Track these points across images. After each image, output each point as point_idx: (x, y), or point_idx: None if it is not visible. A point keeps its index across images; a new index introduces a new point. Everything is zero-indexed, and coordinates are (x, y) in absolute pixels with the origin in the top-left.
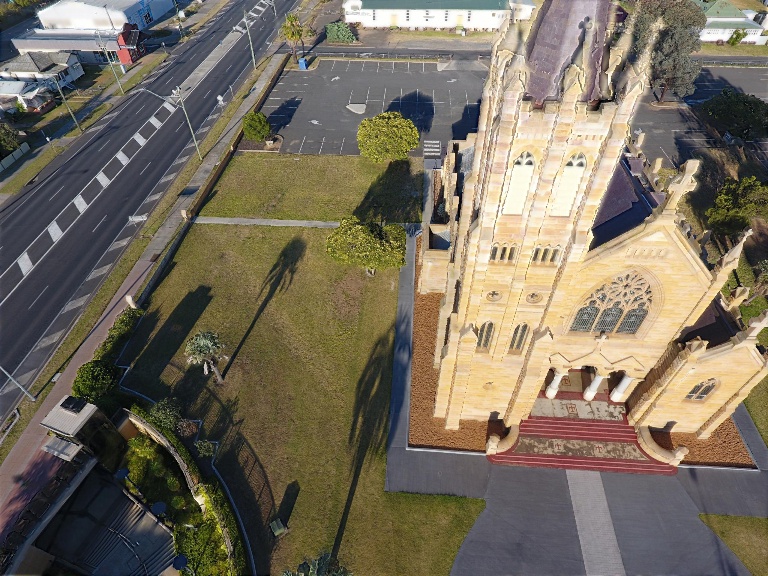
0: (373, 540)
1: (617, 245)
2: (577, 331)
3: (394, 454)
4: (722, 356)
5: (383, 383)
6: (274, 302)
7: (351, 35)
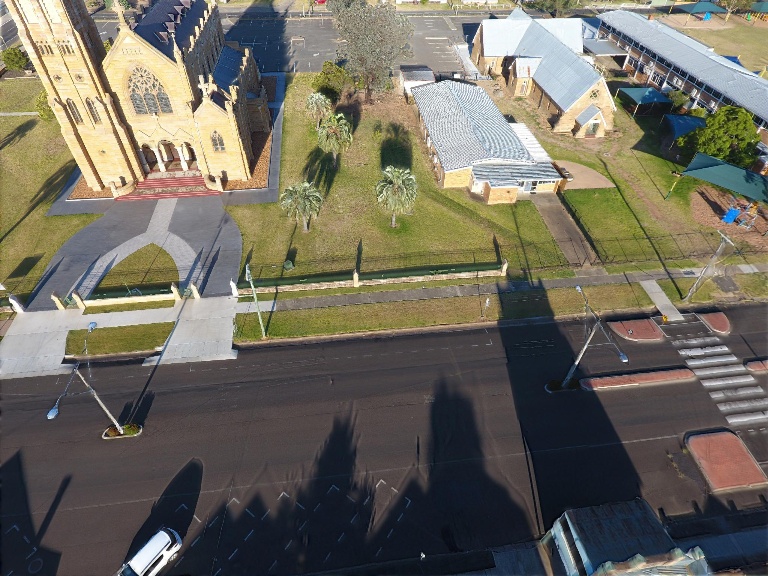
0: (28, 232)
1: (114, 47)
2: (142, 114)
3: (57, 203)
4: (203, 111)
5: (64, 178)
6: (2, 151)
7: (126, 3)
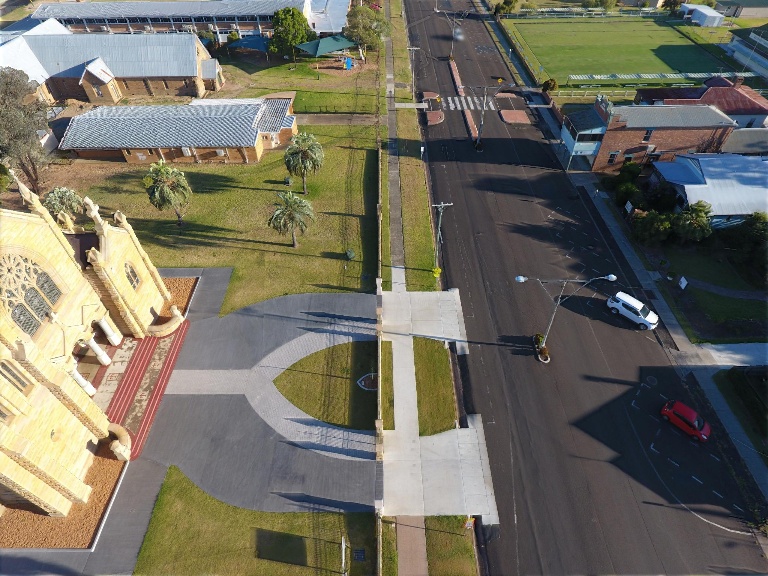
0: None
1: None
2: (34, 334)
3: (93, 567)
4: (109, 247)
5: None
6: None
7: None
